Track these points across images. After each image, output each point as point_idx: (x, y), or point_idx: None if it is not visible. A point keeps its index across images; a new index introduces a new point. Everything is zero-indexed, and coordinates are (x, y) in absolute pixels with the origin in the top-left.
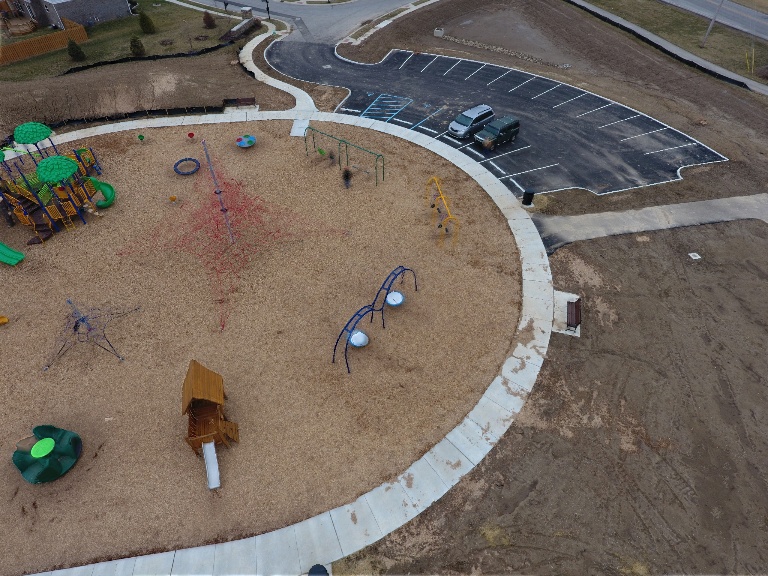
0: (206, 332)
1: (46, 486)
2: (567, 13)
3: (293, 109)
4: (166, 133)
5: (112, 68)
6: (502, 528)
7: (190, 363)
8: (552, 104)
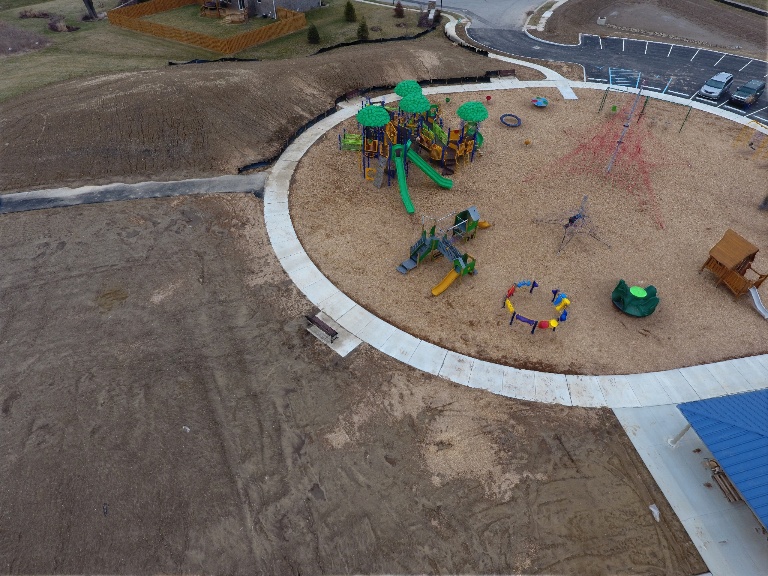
0: (652, 229)
1: (641, 320)
2: (704, 5)
3: (548, 79)
4: (460, 97)
5: (368, 47)
6: None
7: (730, 231)
8: (761, 74)
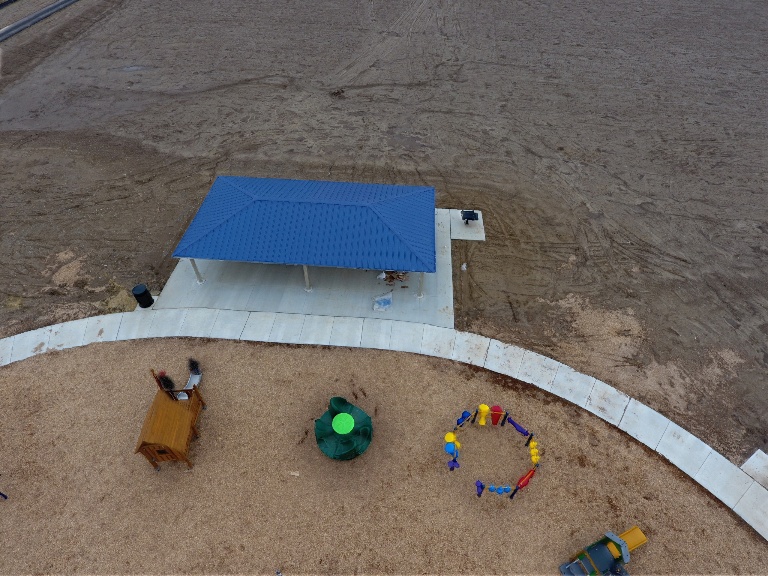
0: None
1: None
2: None
3: None
4: None
5: None
6: (5, 305)
7: (148, 438)
8: None
